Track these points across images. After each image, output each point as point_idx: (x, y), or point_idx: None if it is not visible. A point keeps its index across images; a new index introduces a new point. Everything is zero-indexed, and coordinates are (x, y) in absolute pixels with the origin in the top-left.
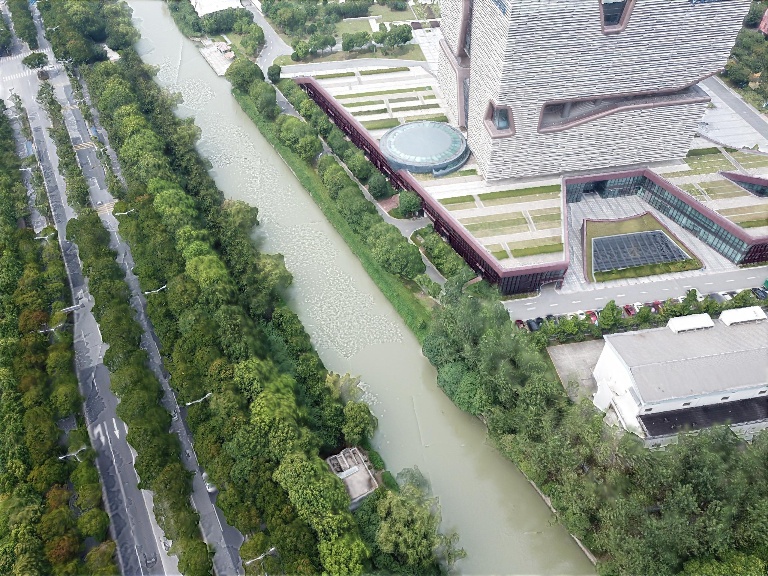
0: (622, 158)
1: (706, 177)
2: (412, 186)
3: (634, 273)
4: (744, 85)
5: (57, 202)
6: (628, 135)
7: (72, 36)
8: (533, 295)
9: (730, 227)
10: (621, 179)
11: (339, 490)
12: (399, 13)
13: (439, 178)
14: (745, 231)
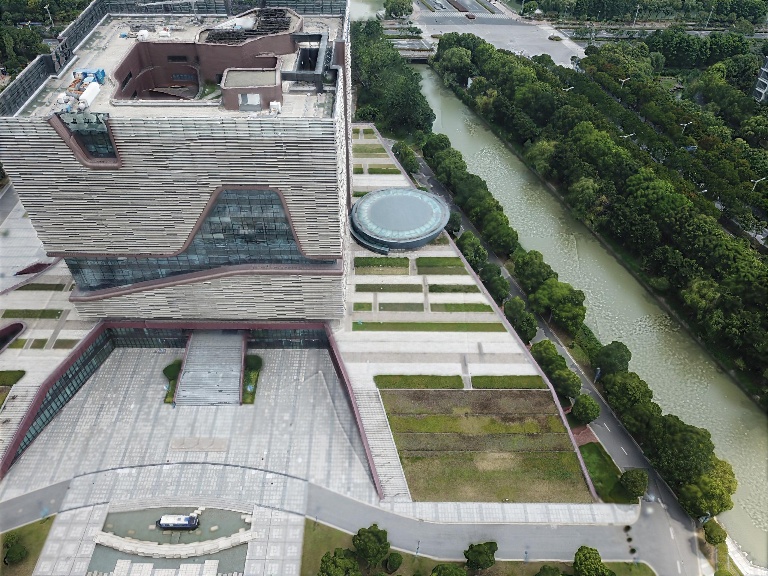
0: None
1: None
2: None
3: None
4: None
5: None
6: None
7: None
8: None
9: None
10: None
11: (488, 63)
12: None
13: None
14: None
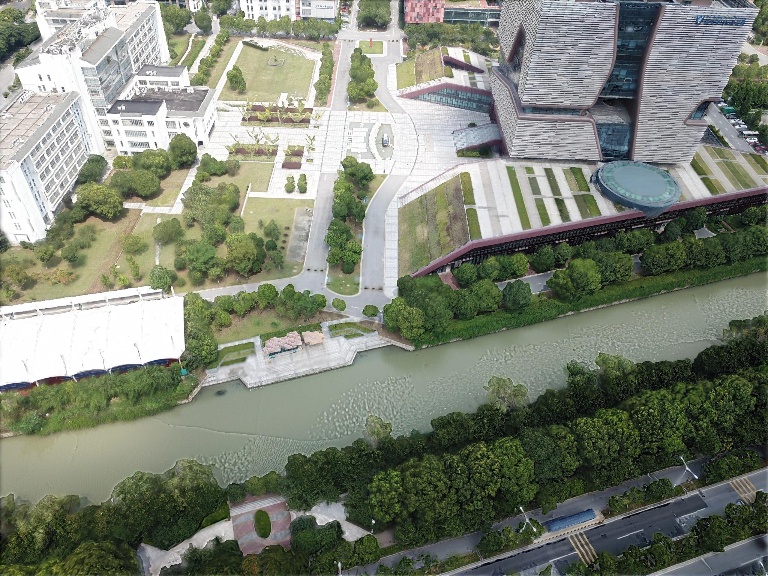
0: None
1: None
2: (686, 208)
3: None
4: None
5: (756, 570)
6: None
7: (225, 573)
8: None
9: None
10: None
11: None
12: (244, 171)
13: None
14: None
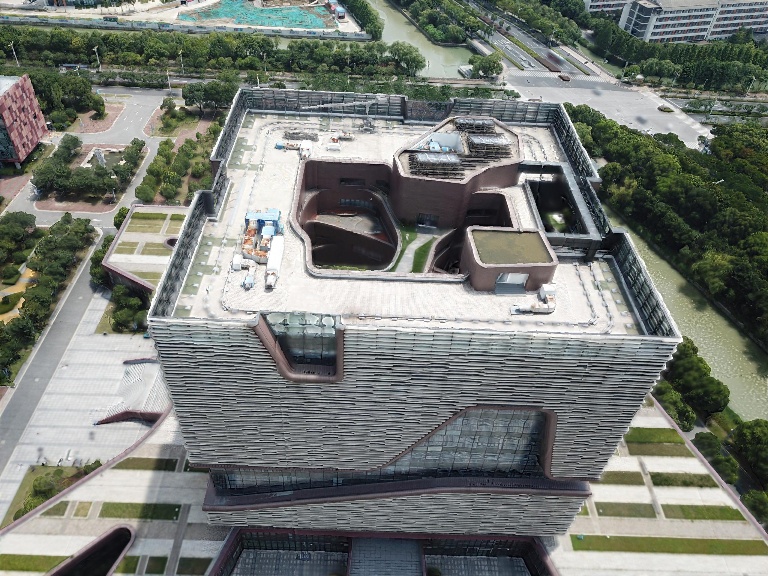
0: None
1: None
2: None
3: None
4: None
5: None
6: None
7: None
8: None
9: None
10: None
11: (615, 144)
12: None
13: None
14: None
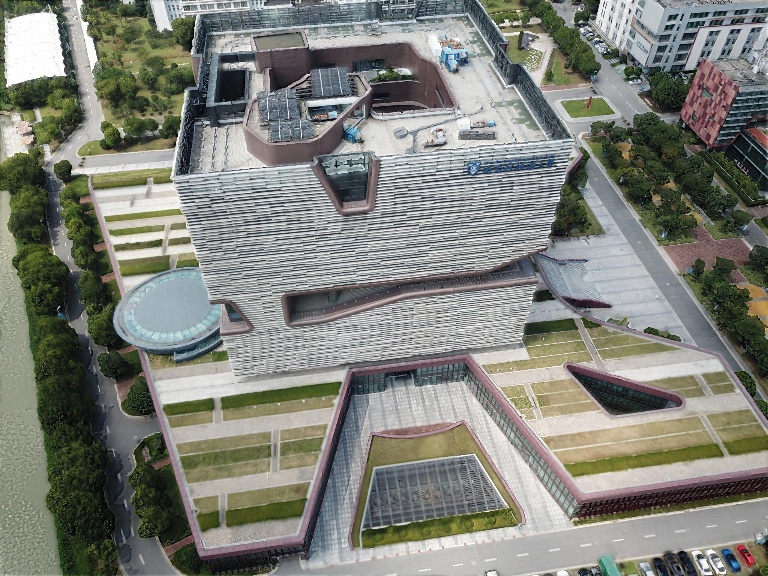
0: (428, 346)
1: (546, 373)
2: None
3: (419, 532)
4: (645, 201)
5: None
6: (427, 323)
7: None
8: (265, 570)
9: (556, 471)
10: (435, 366)
11: None
12: None
13: (182, 364)
14: (575, 482)
